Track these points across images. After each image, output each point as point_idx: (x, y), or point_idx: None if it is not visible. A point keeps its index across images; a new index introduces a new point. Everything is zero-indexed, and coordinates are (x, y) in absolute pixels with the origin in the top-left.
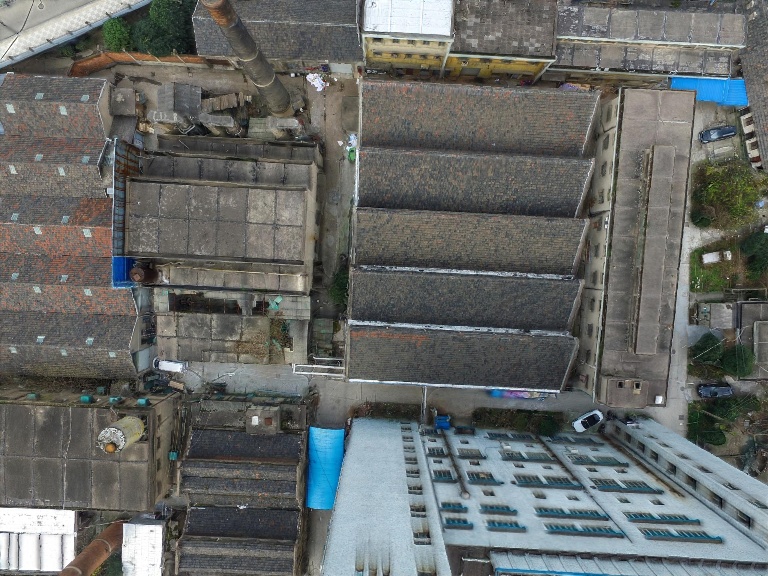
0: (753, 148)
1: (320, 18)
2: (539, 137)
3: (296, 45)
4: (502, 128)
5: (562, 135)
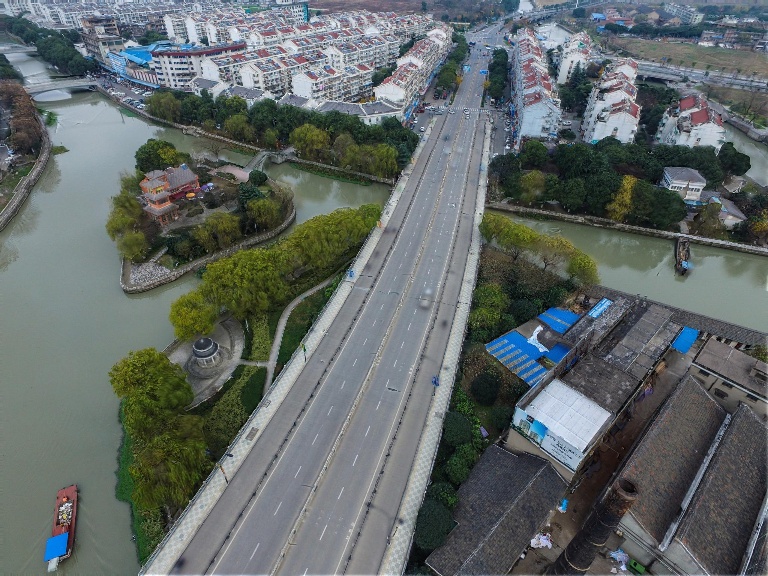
0: (728, 343)
1: (519, 486)
2: (702, 423)
3: (526, 521)
4: (687, 437)
5: (706, 410)
